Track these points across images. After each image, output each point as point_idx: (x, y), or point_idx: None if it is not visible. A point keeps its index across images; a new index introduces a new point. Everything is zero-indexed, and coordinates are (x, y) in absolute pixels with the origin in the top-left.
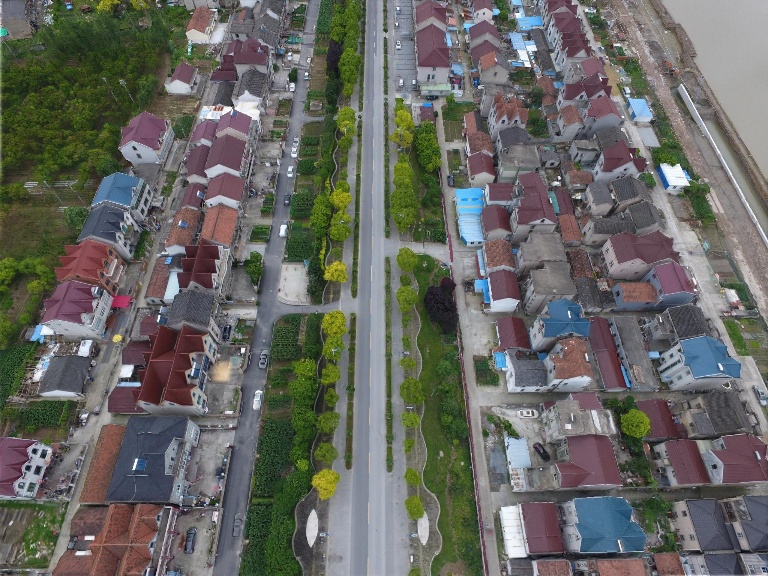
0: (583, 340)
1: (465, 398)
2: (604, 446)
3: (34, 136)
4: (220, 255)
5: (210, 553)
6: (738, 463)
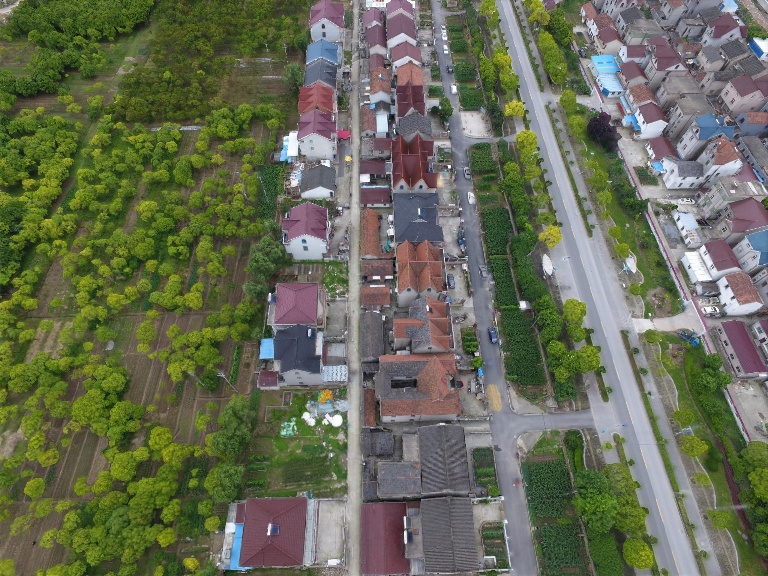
0: (729, 141)
1: (636, 191)
2: (760, 206)
3: (228, 23)
4: None
5: (470, 286)
6: None
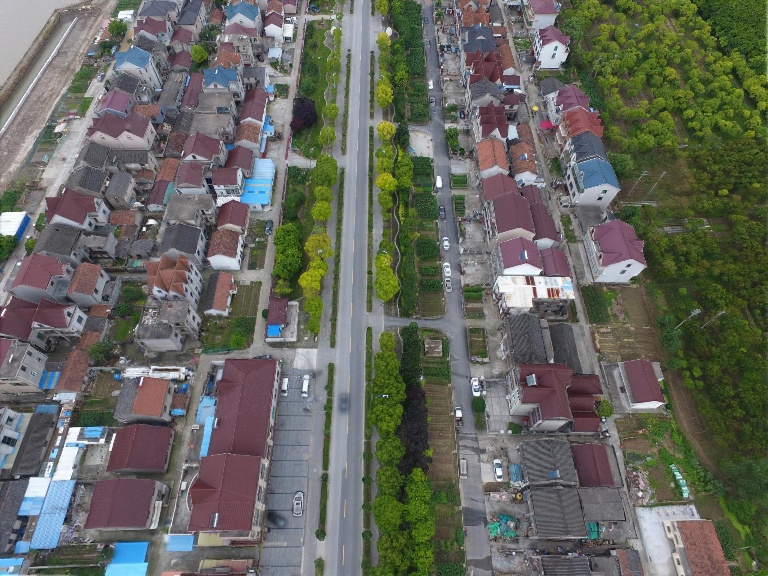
0: None
1: None
2: None
3: None
4: None
5: None
6: (158, 21)
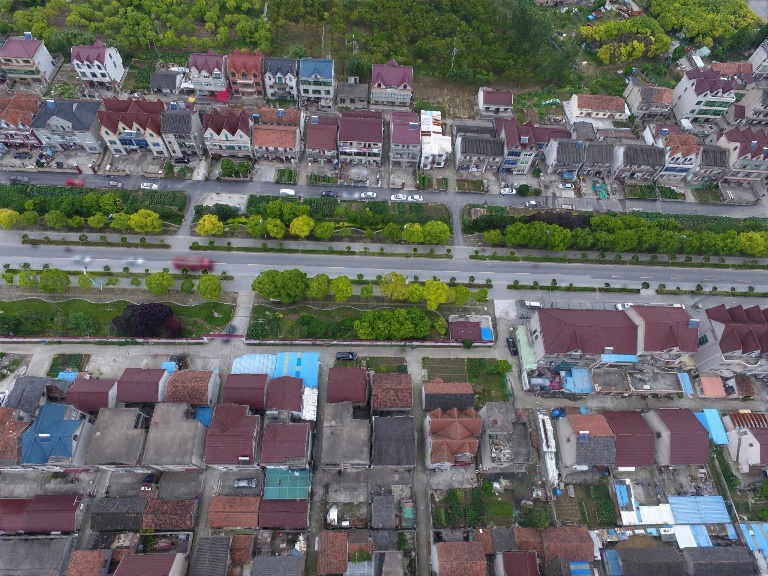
0: (18, 455)
1: None
2: None
3: None
4: (239, 137)
5: (6, 165)
6: None
